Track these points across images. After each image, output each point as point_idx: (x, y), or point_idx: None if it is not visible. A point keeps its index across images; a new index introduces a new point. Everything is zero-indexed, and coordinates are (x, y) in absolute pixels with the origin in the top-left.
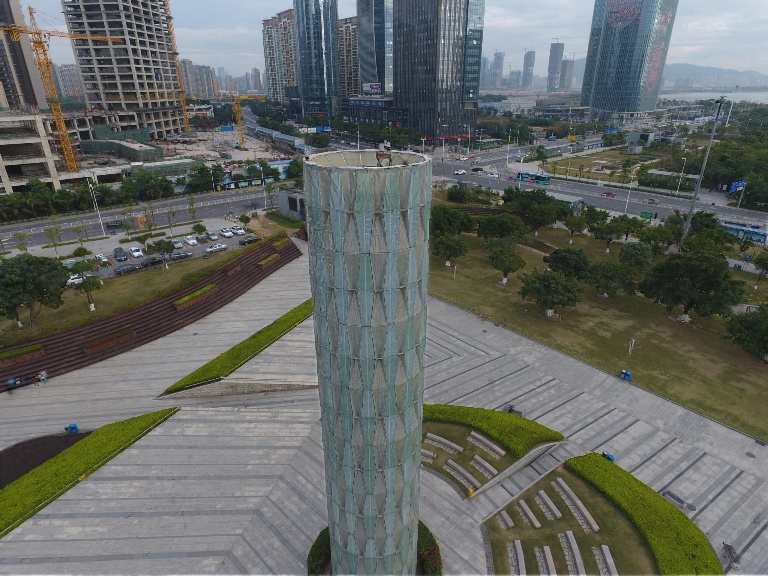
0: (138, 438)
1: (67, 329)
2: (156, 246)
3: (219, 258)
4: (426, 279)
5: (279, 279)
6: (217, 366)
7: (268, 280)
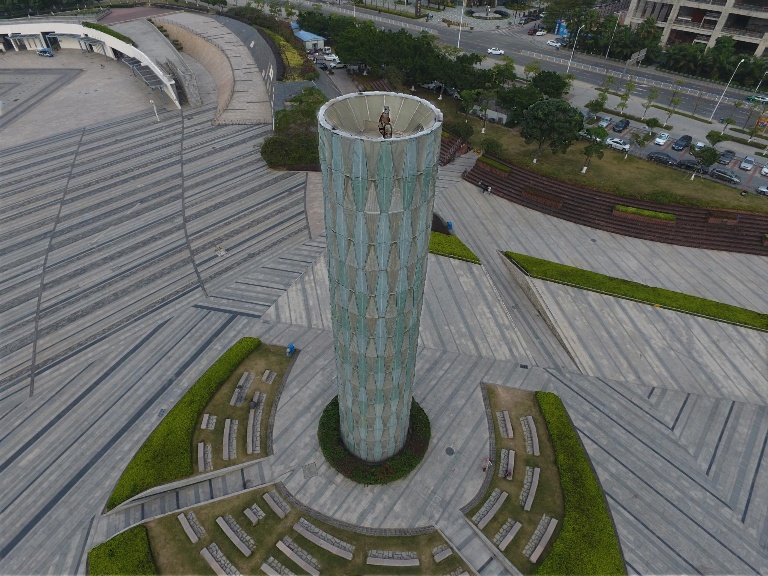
0: (444, 255)
1: (533, 171)
2: (698, 151)
3: (756, 203)
4: (366, 247)
5: (762, 267)
6: (546, 267)
7: (749, 258)
